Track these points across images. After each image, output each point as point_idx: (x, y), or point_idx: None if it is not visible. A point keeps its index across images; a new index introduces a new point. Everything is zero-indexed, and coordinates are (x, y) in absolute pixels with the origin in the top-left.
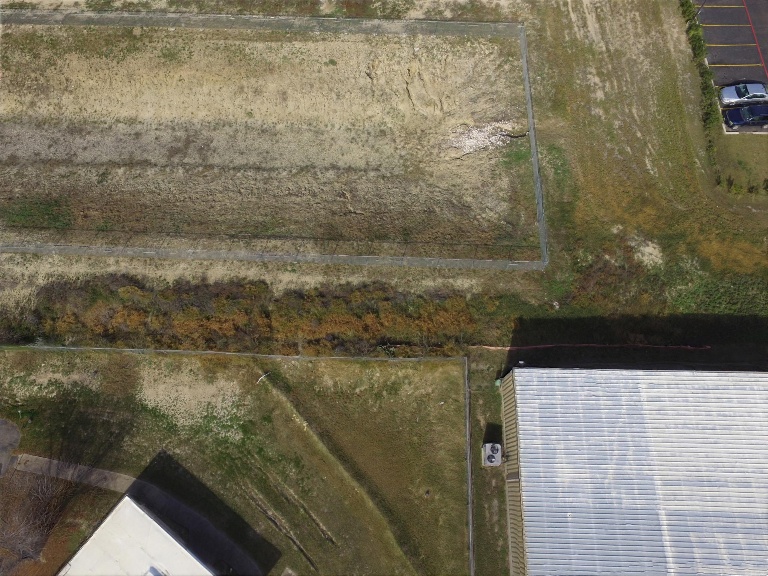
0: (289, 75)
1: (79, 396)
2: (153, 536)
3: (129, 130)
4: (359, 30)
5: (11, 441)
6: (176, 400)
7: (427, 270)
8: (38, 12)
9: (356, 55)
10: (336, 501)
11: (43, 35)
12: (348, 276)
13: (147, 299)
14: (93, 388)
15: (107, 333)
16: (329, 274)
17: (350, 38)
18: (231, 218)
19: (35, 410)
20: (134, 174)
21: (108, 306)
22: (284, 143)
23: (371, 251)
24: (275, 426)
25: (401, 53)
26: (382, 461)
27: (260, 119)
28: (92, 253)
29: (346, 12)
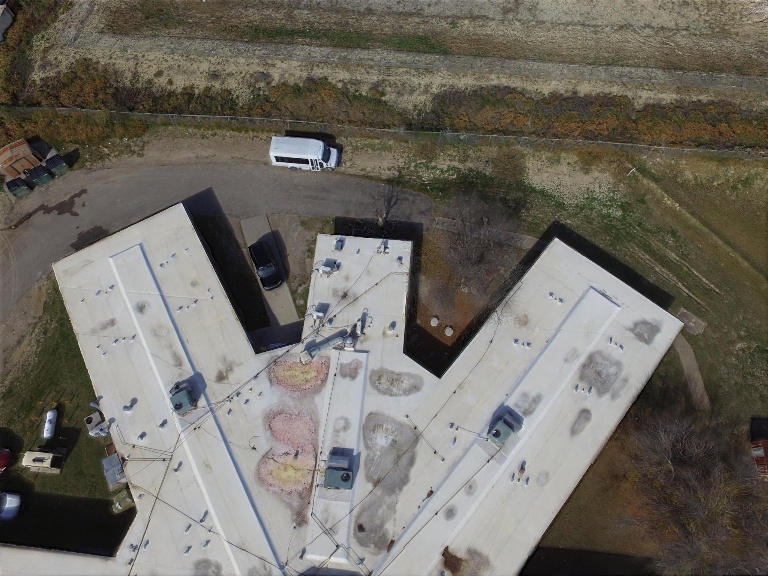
0: None
1: (476, 178)
2: (586, 265)
3: None
4: None
5: (426, 208)
6: (559, 185)
7: (764, 95)
8: None
9: None
10: (713, 263)
11: None
12: (698, 96)
13: (528, 106)
14: (487, 173)
15: (498, 130)
16: (681, 94)
17: None
18: (581, 53)
19: (441, 187)
20: (478, 24)
21: (494, 111)
22: (601, 7)
23: (713, 79)
24: (649, 206)
25: None
26: (747, 236)
27: None
28: (475, 70)
29: None
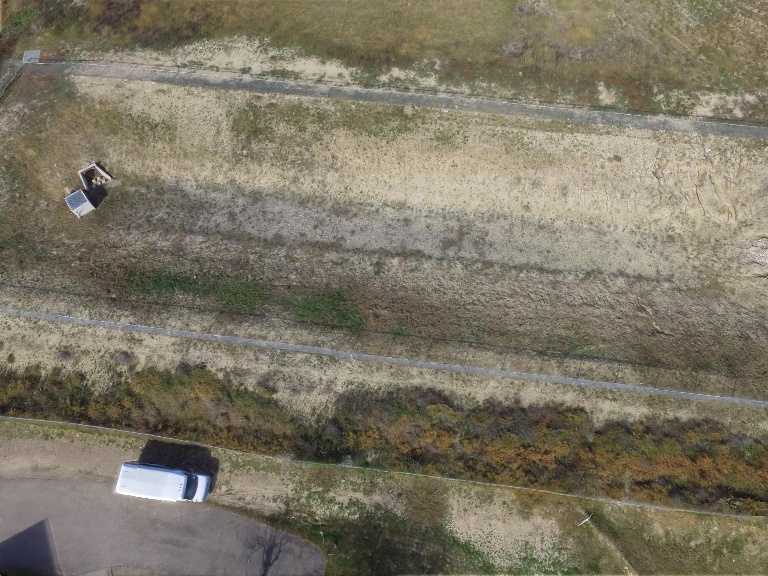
0: (570, 169)
1: (384, 521)
2: None
3: (397, 215)
4: (645, 125)
5: (316, 567)
6: (490, 536)
7: (762, 411)
8: (302, 82)
9: (642, 152)
10: None
11: (309, 108)
12: (676, 411)
13: (456, 418)
14: (399, 513)
15: (415, 454)
16: (654, 407)
17: (636, 133)
18: (531, 329)
19: (338, 533)
20: (410, 266)
21: (413, 422)
22: (565, 242)
23: (697, 384)
24: None
25: (691, 153)
26: None
27: (537, 214)
28: (393, 360)
29: (628, 104)
